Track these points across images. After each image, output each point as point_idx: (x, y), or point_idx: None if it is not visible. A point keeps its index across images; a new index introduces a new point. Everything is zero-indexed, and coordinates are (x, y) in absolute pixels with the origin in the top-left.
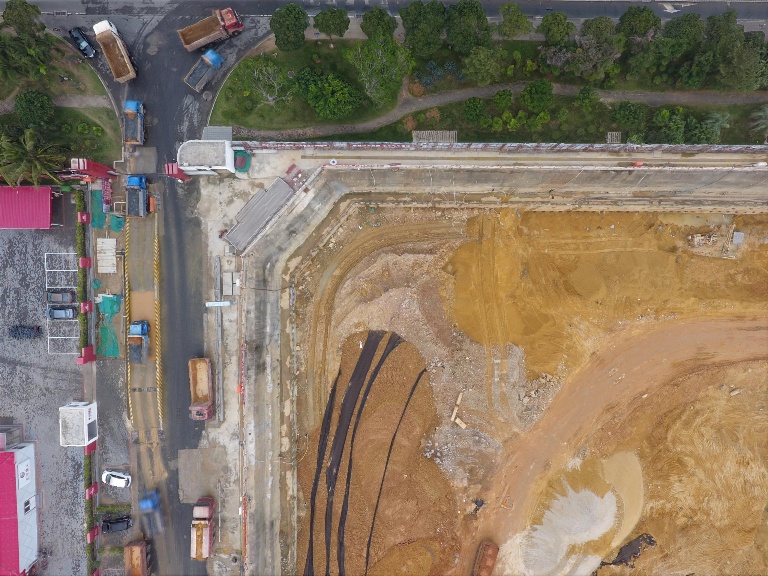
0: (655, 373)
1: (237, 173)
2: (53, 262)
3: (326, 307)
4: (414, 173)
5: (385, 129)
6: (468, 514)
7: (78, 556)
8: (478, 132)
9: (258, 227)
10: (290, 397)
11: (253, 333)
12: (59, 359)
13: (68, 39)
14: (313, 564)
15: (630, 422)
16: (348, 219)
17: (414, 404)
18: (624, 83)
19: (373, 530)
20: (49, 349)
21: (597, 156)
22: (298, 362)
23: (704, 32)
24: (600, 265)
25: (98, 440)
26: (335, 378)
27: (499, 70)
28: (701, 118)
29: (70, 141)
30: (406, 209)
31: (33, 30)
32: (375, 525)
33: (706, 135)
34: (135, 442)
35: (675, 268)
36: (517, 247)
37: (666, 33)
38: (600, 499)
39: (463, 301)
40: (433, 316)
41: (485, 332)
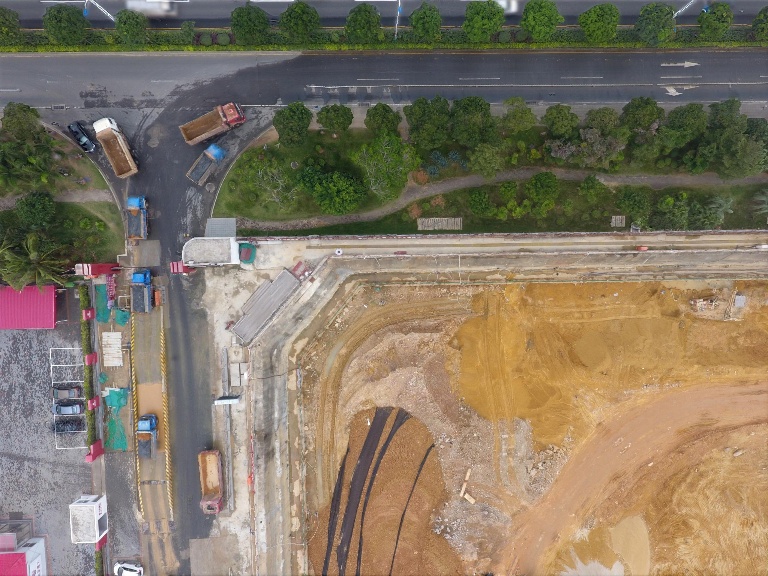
0: (660, 441)
1: (242, 264)
2: (58, 357)
3: (333, 386)
4: (420, 260)
5: (390, 217)
6: None
7: None
8: (483, 218)
9: (265, 318)
10: (299, 477)
11: (262, 422)
12: (67, 453)
13: (67, 133)
14: None
15: (636, 490)
16: (353, 299)
17: (423, 480)
18: (627, 167)
19: None
20: (57, 444)
21: (602, 240)
22: (306, 442)
23: (707, 121)
24: (604, 333)
25: (109, 532)
26: (344, 456)
27: (504, 164)
28: (704, 201)
29: (72, 236)
30: (411, 287)
31: (32, 133)
32: None
33: (710, 221)
34: (146, 533)
35: (678, 334)
36: (522, 318)
37: (669, 123)
38: (609, 570)
39: (470, 376)
40: (440, 392)
41: (492, 408)
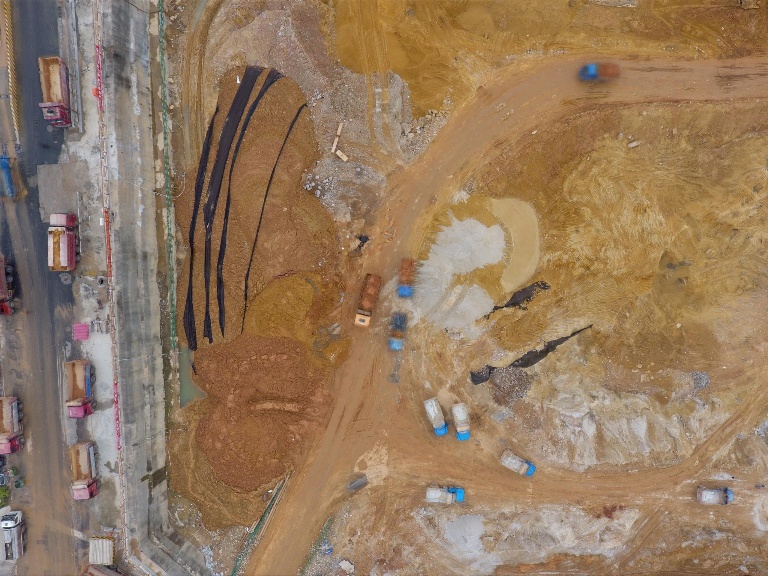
0: (544, 109)
1: None
2: None
3: (200, 39)
4: None
5: None
6: (352, 250)
7: None
8: None
9: None
10: None
11: (111, 38)
12: None
13: None
14: (193, 304)
15: (519, 159)
16: None
17: (294, 138)
18: None
19: (252, 263)
20: None
21: None
22: (172, 96)
23: None
24: (489, 6)
25: None
26: (212, 115)
27: None
28: None
29: None
30: None
31: None
32: (254, 258)
33: None
34: None
35: (567, 9)
36: None
37: None
38: (485, 227)
39: (343, 32)
40: (313, 49)
41: (365, 60)
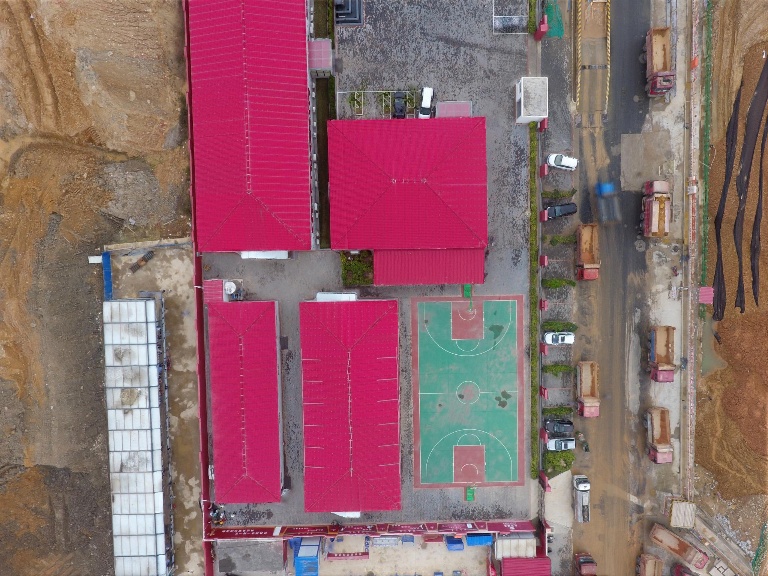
0: None
1: None
2: None
3: (731, 15)
4: None
5: None
6: None
7: (518, 246)
8: None
9: None
10: (701, 103)
11: (701, 10)
12: (504, 39)
13: None
14: (724, 275)
15: None
16: None
17: None
18: None
19: None
20: (494, 29)
21: None
22: None
23: None
24: None
25: None
26: (737, 89)
27: None
28: None
29: None
30: None
31: None
32: None
33: None
34: (578, 126)
35: None
36: None
37: None
38: None
39: None
40: None
41: None
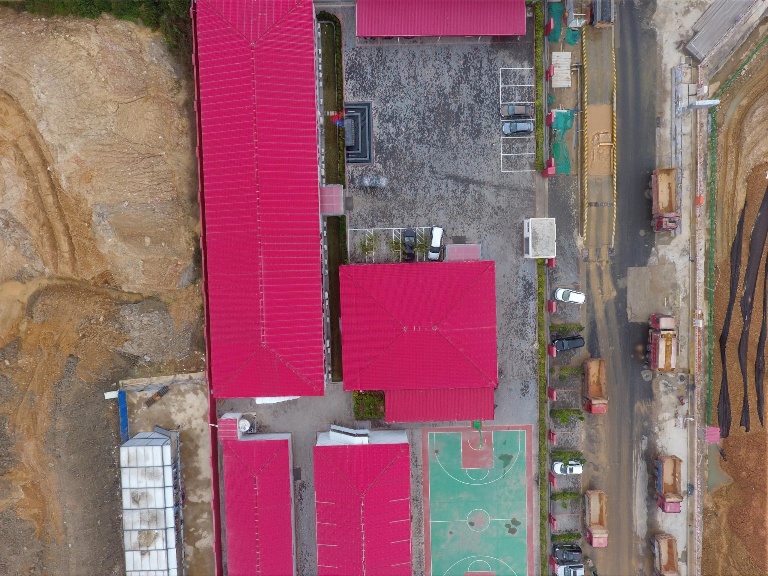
0: None
1: None
2: (508, 77)
3: (734, 137)
4: None
5: None
6: None
7: (527, 377)
8: None
9: (719, 35)
10: (706, 226)
11: (706, 146)
12: (512, 176)
13: None
14: (729, 394)
15: None
16: None
17: None
18: None
19: None
20: (502, 166)
21: None
22: None
23: None
24: None
25: None
26: (741, 210)
27: None
28: None
29: None
30: None
31: None
32: None
33: None
34: (585, 260)
35: None
36: None
37: None
38: None
39: None
40: None
41: None
